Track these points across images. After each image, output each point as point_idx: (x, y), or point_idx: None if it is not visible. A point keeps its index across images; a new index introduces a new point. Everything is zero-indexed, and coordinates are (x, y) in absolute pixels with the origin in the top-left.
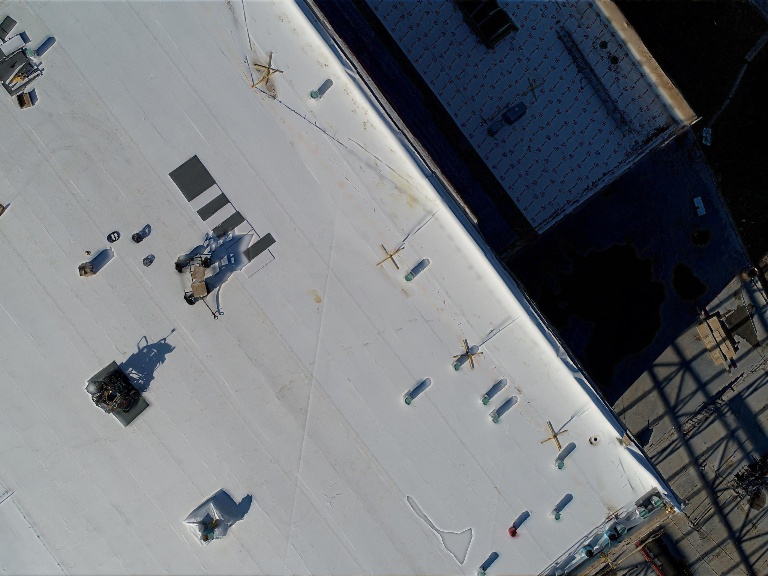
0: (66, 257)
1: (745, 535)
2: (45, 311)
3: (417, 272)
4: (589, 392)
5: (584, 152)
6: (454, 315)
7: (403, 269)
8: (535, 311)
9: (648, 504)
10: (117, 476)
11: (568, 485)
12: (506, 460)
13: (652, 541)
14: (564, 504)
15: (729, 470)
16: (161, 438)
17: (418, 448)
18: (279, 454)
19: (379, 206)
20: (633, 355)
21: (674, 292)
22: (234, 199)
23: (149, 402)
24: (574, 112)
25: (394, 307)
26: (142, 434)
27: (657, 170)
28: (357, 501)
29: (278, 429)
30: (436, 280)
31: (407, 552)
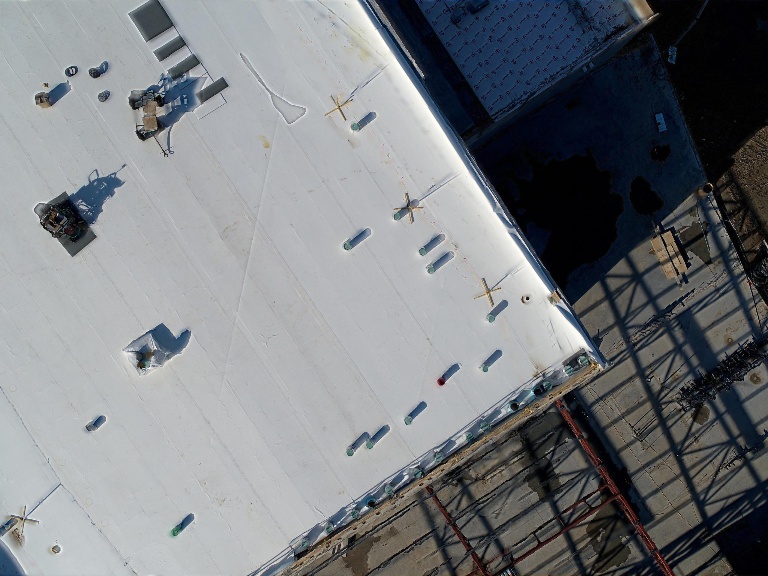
0: (24, 88)
1: (687, 448)
2: (1, 139)
3: (364, 124)
4: (522, 248)
5: (544, 45)
6: (397, 169)
7: (350, 120)
8: (475, 166)
9: (575, 364)
10: (62, 304)
11: (498, 341)
12: (439, 313)
13: (595, 449)
14: (493, 359)
15: (675, 383)
16: (106, 270)
17: (355, 296)
18: (220, 293)
19: (330, 58)
20: (587, 265)
21: (631, 205)
22: (190, 42)
23: (96, 234)
24: (536, 6)
25: (339, 157)
26: (88, 265)
27: (621, 84)
28: (292, 343)
29: (220, 268)
30: (382, 133)
31: (338, 396)
